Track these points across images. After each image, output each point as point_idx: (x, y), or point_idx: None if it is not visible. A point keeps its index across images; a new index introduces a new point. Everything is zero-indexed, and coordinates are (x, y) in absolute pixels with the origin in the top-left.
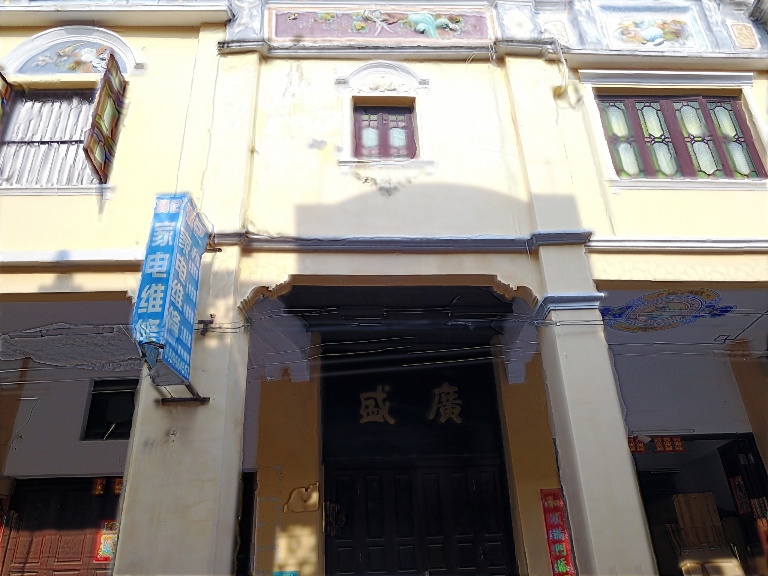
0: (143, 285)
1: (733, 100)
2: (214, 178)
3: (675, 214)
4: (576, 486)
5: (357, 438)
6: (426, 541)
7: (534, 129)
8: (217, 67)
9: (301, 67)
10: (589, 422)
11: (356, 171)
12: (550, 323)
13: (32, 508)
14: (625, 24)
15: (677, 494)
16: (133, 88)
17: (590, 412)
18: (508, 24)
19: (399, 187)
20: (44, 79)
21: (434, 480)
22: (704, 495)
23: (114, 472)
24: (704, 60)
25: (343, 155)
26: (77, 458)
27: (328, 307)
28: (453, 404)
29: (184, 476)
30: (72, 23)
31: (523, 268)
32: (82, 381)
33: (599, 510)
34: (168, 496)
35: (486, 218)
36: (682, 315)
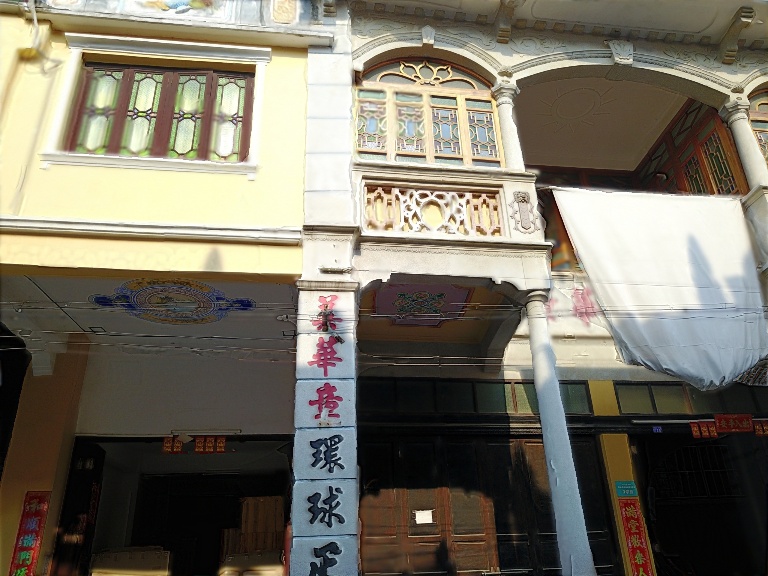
0: None
1: (250, 77)
2: None
3: (107, 194)
4: None
5: None
6: None
7: None
8: None
9: None
10: None
11: None
12: None
13: None
14: None
15: (244, 497)
16: None
17: None
18: None
19: None
20: None
21: None
22: (271, 499)
23: None
24: (213, 31)
25: None
26: None
27: None
28: None
29: None
30: None
31: None
32: None
33: None
34: None
35: None
36: (204, 307)
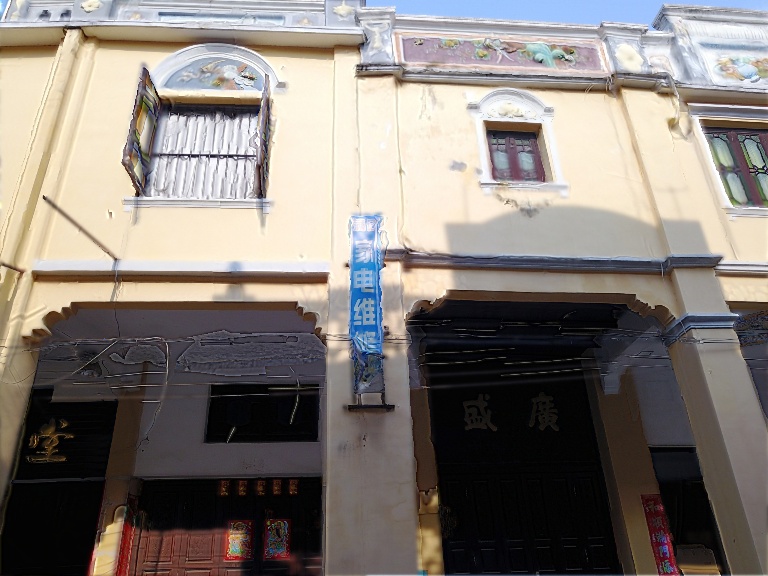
0: (354, 299)
1: None
2: (369, 196)
3: None
4: (731, 492)
5: (463, 444)
6: (534, 543)
7: (656, 158)
8: (356, 89)
9: (433, 91)
10: (738, 433)
11: (497, 193)
12: (694, 341)
13: (160, 508)
14: (723, 61)
15: None
16: (277, 106)
17: (738, 424)
18: (620, 57)
19: (538, 209)
20: (190, 94)
21: (537, 485)
22: None
23: (239, 474)
24: None
25: (483, 177)
26: (203, 460)
27: (446, 319)
28: (550, 413)
29: (380, 478)
30: (213, 41)
31: (658, 288)
32: (202, 385)
33: (757, 514)
34: (368, 497)
35: (621, 241)
36: None
